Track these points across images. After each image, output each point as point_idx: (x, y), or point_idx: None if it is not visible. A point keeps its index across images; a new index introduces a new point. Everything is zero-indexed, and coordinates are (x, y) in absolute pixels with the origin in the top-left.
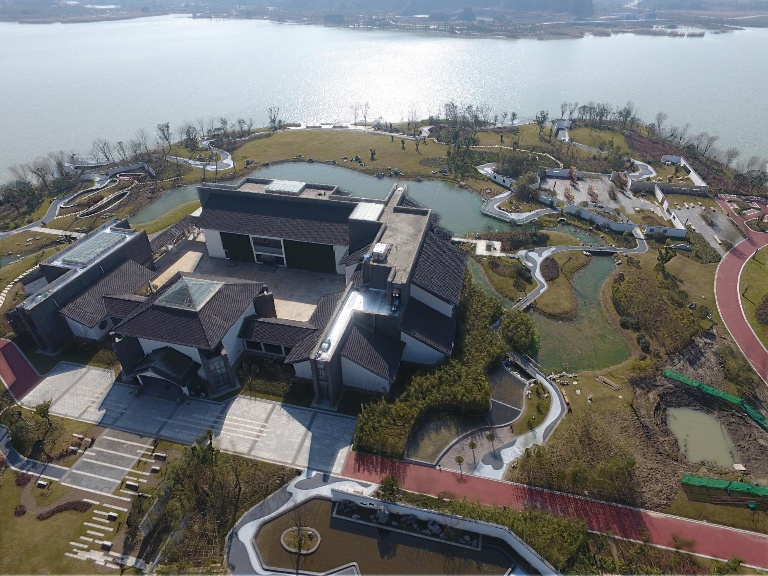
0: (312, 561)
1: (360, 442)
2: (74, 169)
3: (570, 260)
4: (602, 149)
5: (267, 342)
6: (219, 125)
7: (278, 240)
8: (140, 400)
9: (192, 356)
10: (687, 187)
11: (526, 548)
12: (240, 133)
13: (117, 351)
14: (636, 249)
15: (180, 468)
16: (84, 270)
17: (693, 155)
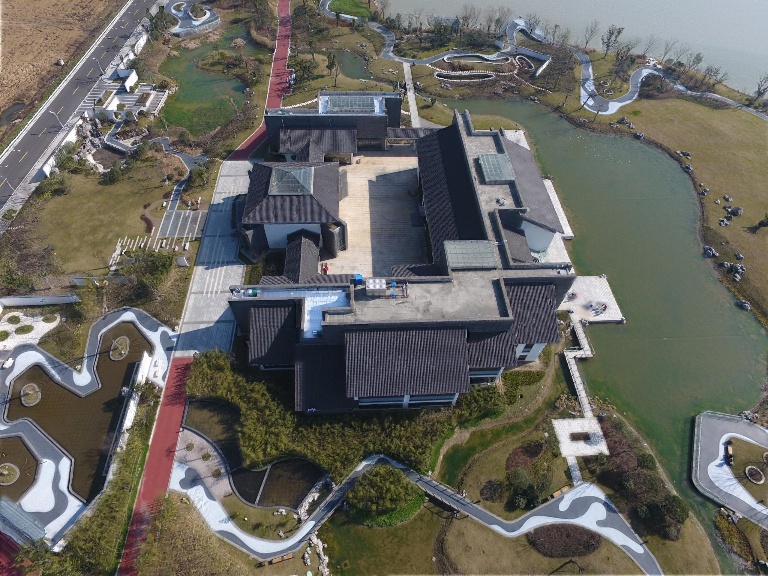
0: (105, 360)
1: None
2: (516, 30)
3: None
4: None
5: None
6: (686, 60)
7: None
8: None
9: None
10: None
11: (85, 508)
12: (697, 83)
13: None
14: None
15: None
16: None
17: None
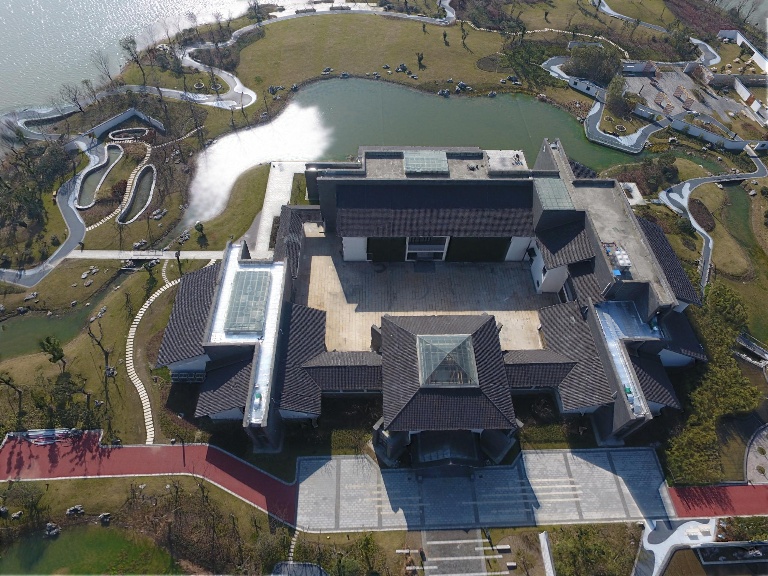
0: None
1: (683, 481)
2: (26, 128)
3: (725, 204)
4: (669, 31)
5: (526, 386)
6: (188, 24)
7: (443, 237)
8: (427, 486)
9: (473, 429)
10: (764, 77)
11: None
12: (219, 33)
13: (392, 447)
14: (758, 172)
15: (571, 573)
16: None
17: (740, 24)
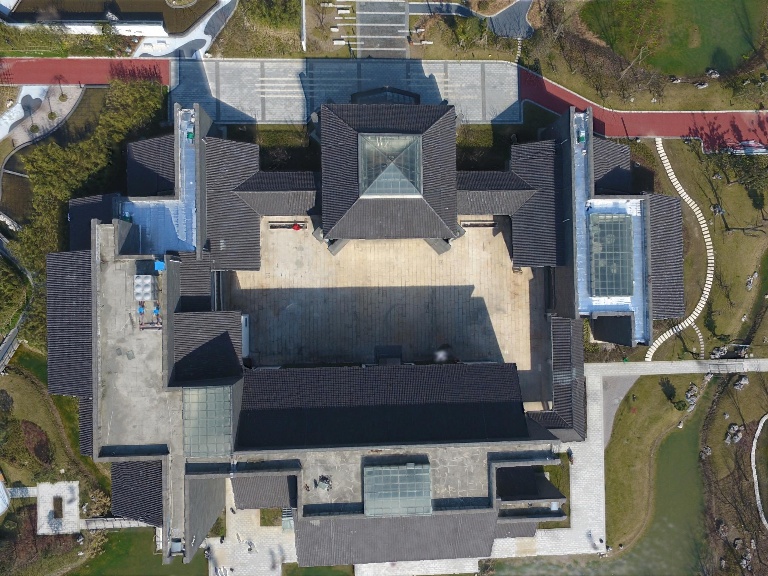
0: None
1: None
2: None
3: None
4: None
5: None
6: None
7: None
8: None
9: None
10: None
11: None
12: None
13: None
14: None
15: (291, 1)
16: None
17: None
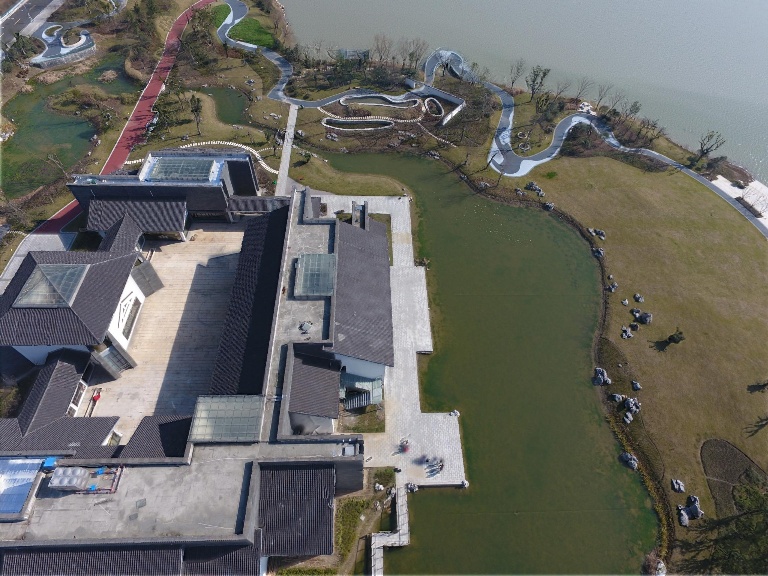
0: None
1: None
2: (438, 64)
3: None
4: None
5: None
6: None
7: None
8: None
9: None
10: None
11: None
12: (632, 137)
13: None
14: None
15: None
16: (136, 184)
17: None
